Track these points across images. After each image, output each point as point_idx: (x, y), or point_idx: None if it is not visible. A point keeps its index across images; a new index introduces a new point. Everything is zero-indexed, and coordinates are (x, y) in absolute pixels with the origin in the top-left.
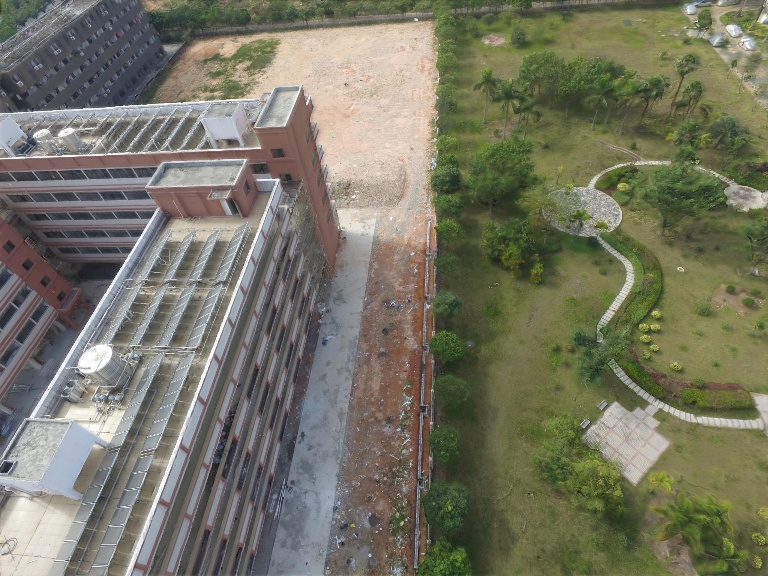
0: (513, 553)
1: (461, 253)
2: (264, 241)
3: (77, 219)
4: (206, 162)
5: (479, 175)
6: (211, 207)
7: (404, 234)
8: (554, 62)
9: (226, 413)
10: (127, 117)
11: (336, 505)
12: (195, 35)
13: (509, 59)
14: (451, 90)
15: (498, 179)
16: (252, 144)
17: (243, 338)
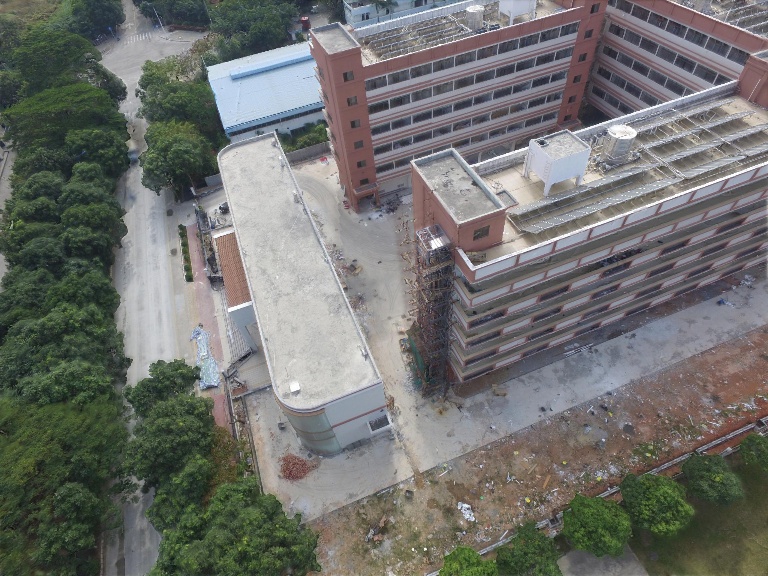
0: (722, 575)
1: None
2: None
3: (634, 69)
4: None
5: None
6: None
7: None
8: None
9: (649, 240)
10: (767, 5)
11: (612, 393)
12: None
13: None
14: None
15: None
16: None
17: (712, 208)
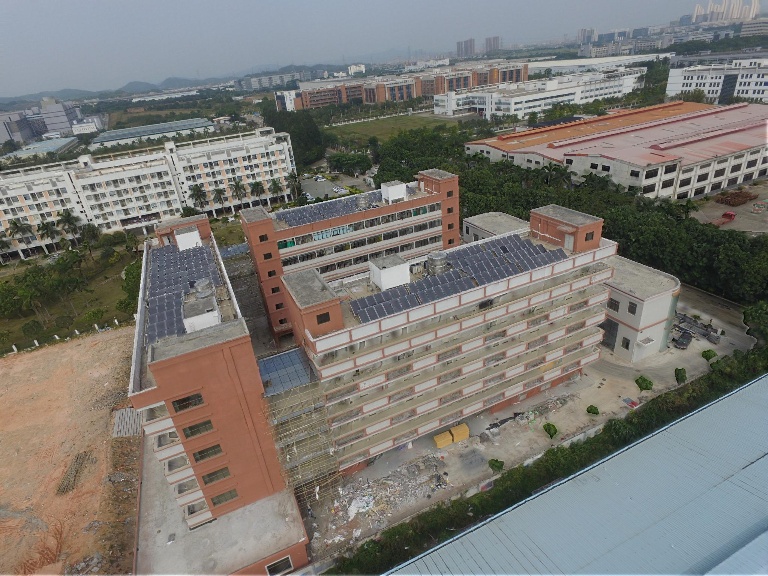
0: None
1: None
2: None
3: None
4: None
5: None
6: None
7: None
8: None
9: None
10: None
11: None
12: None
13: None
14: None
15: None
16: None
17: None
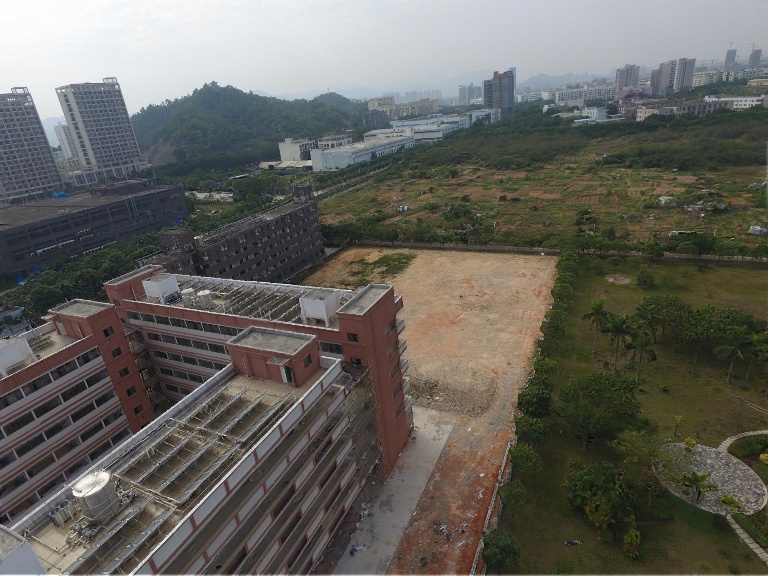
0: None
1: (539, 489)
2: (302, 414)
3: (186, 362)
4: (283, 332)
5: (570, 403)
6: (272, 371)
7: (479, 450)
8: (679, 306)
9: None
10: (254, 290)
11: None
12: (352, 244)
13: (633, 298)
14: (561, 316)
15: (591, 412)
16: (336, 326)
17: (238, 509)
